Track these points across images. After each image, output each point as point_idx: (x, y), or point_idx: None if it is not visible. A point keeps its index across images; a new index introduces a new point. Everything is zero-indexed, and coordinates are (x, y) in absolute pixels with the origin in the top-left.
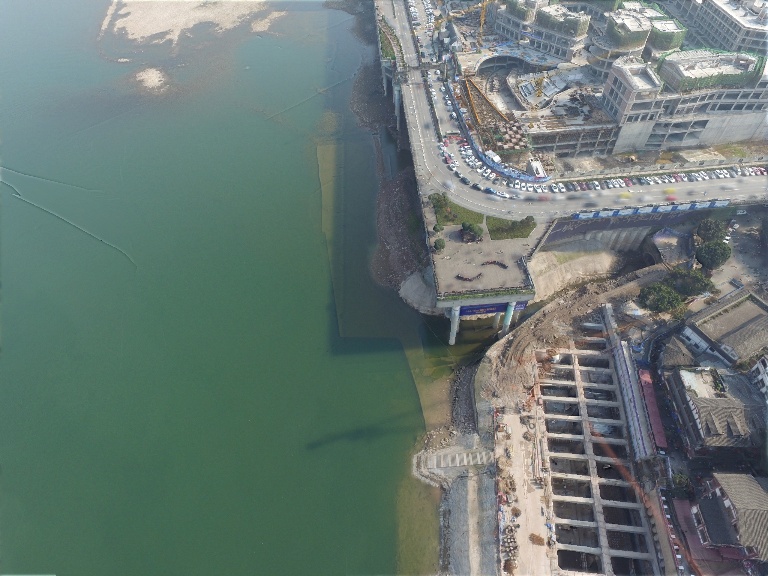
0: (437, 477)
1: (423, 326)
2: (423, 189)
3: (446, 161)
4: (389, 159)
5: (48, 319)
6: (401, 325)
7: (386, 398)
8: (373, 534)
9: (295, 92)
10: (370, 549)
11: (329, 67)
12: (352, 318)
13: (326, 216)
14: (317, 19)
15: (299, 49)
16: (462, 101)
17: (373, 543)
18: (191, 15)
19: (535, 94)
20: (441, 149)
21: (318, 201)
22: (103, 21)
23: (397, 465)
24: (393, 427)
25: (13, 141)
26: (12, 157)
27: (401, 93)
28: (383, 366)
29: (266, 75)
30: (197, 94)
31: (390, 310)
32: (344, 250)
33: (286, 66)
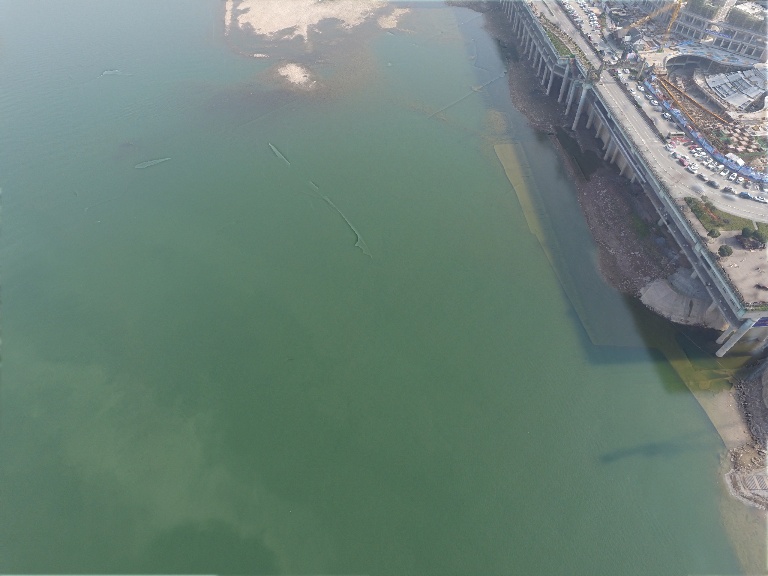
0: (763, 499)
1: (680, 336)
2: (671, 192)
3: (682, 163)
4: (575, 160)
5: (272, 317)
6: (655, 334)
7: (667, 411)
8: (712, 558)
9: (449, 90)
10: (715, 575)
11: None
12: (599, 325)
13: (530, 218)
14: (444, 16)
15: (436, 46)
16: None
17: (716, 568)
18: (312, 11)
19: (735, 95)
20: (670, 151)
21: (515, 202)
22: (225, 16)
23: (709, 484)
24: (689, 443)
25: (176, 135)
26: (176, 151)
27: (597, 92)
28: (653, 377)
29: (410, 72)
30: (348, 90)
31: (637, 318)
32: (563, 253)
33: (427, 63)
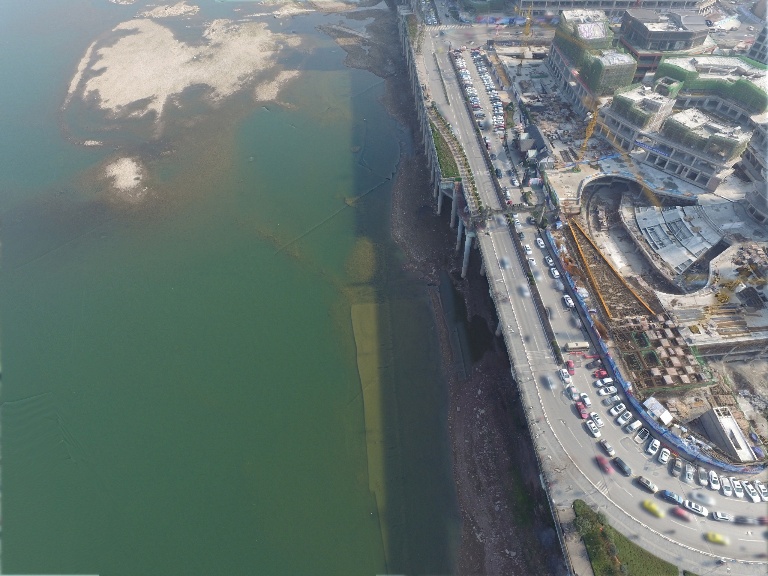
0: None
1: None
2: (554, 487)
3: (579, 413)
4: (457, 335)
5: None
6: None
7: None
8: None
9: (315, 202)
10: None
11: (357, 158)
12: None
13: (374, 454)
14: (338, 83)
15: (317, 130)
16: (577, 274)
17: None
18: (181, 74)
19: (672, 248)
20: (564, 381)
21: (359, 419)
22: (71, 80)
23: None
24: None
25: None
26: None
27: None
28: None
29: (276, 170)
30: (184, 203)
31: None
32: (408, 538)
33: (301, 155)
